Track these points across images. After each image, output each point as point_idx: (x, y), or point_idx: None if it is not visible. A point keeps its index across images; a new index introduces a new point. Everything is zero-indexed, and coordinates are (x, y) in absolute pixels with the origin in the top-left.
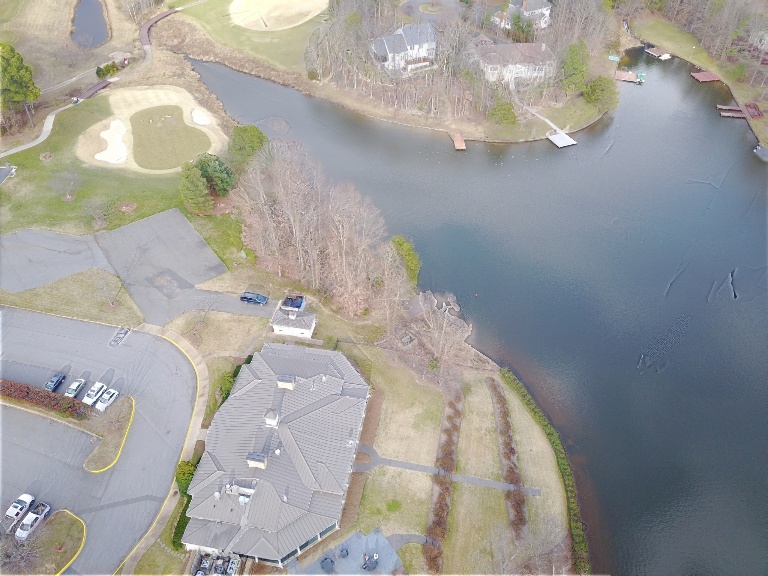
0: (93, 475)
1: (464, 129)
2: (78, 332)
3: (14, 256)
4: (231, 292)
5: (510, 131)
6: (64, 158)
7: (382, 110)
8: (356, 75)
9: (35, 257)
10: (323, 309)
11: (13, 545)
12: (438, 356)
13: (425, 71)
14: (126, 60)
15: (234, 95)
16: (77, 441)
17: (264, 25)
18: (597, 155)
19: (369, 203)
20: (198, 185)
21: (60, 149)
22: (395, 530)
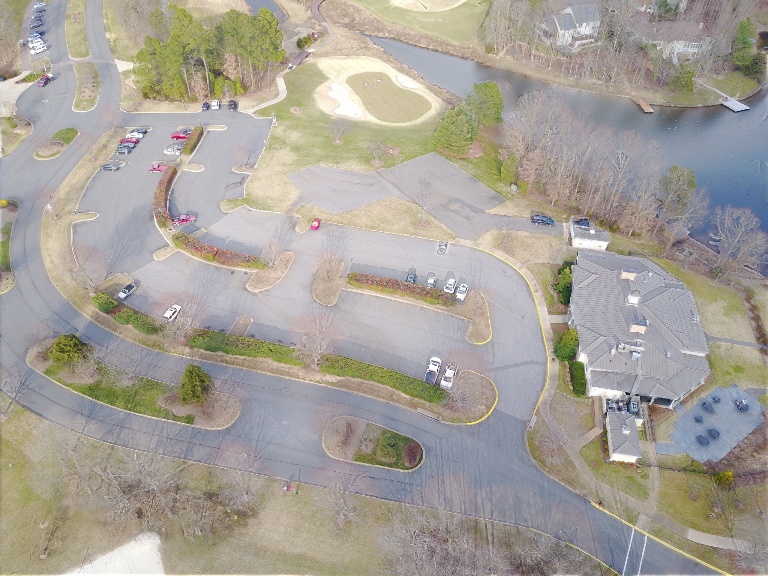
0: (478, 346)
1: (644, 96)
2: (406, 244)
3: (318, 186)
4: (518, 216)
5: (686, 98)
6: (312, 111)
7: (564, 79)
8: (528, 50)
9: (337, 187)
10: None
11: None
12: (721, 265)
13: (591, 47)
14: (316, 34)
15: (423, 65)
16: (451, 322)
17: (423, 7)
18: (755, 122)
19: (641, 140)
20: (463, 130)
21: (304, 104)
22: (748, 385)
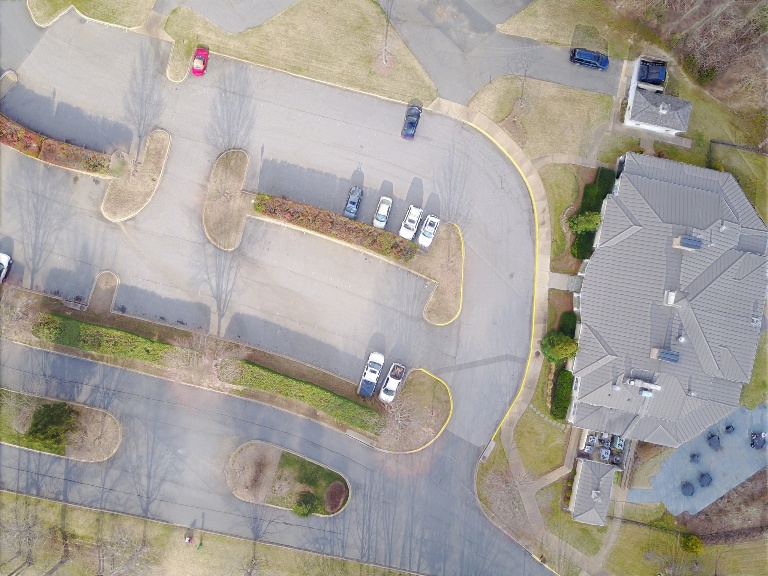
0: (438, 329)
1: None
2: (352, 112)
3: None
4: (551, 41)
5: None
6: None
7: None
8: None
9: None
10: (686, 78)
11: (380, 407)
12: None
13: None
14: None
15: None
16: (406, 284)
17: None
18: None
19: None
20: None
21: None
22: None
